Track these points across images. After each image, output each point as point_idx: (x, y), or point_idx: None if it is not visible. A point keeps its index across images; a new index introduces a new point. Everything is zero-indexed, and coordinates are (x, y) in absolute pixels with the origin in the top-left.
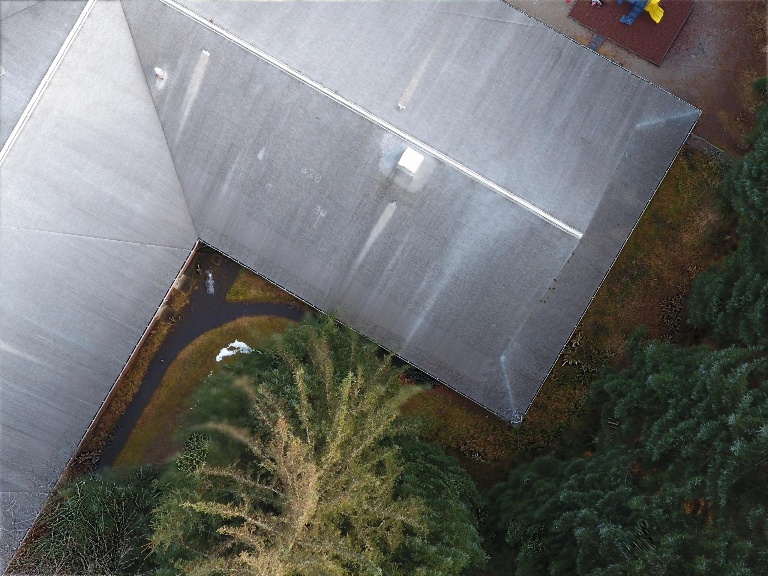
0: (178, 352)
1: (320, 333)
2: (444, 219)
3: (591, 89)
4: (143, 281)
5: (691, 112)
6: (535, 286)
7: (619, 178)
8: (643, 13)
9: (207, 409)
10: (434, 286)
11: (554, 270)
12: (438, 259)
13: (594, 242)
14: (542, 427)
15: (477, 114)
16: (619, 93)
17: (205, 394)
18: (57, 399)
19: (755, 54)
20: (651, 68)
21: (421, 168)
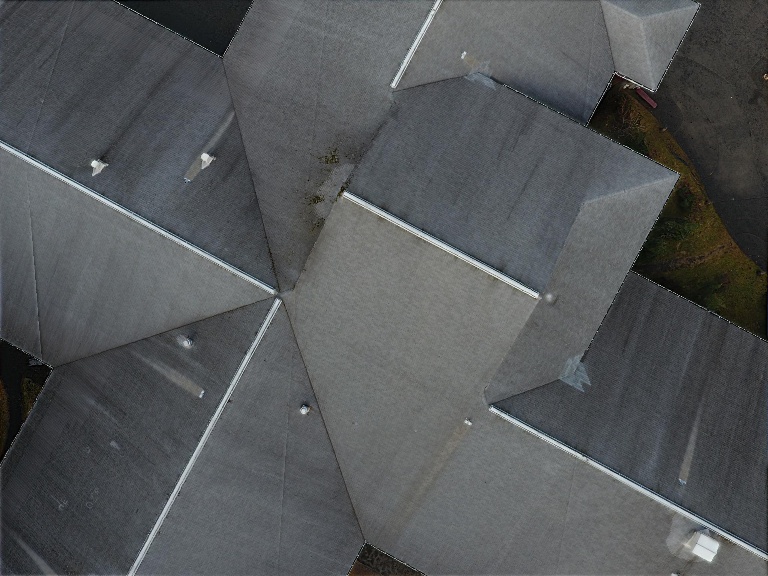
0: None
1: None
2: None
3: None
4: (6, 317)
5: None
6: None
7: None
8: None
9: None
10: None
11: None
12: None
13: None
14: None
15: None
16: None
17: None
18: None
19: None
20: None
21: None
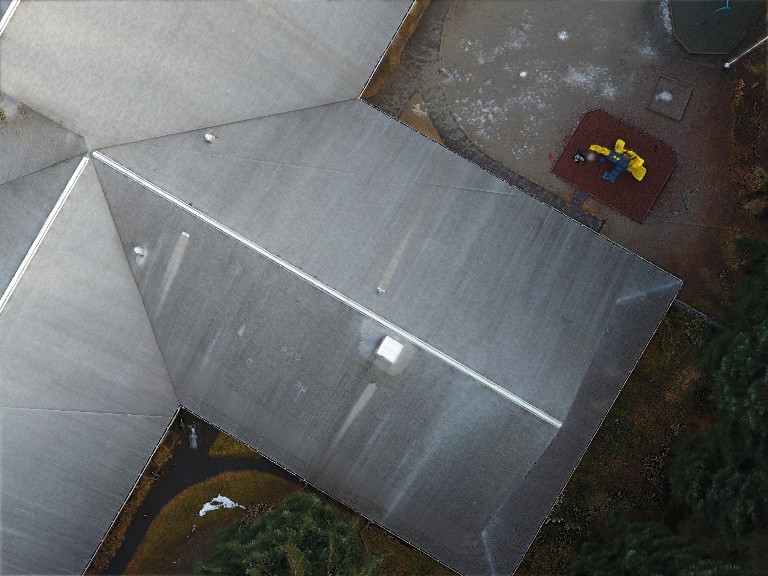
0: (161, 507)
1: (298, 531)
2: (424, 402)
3: (572, 262)
4: (124, 450)
5: (672, 283)
6: (515, 469)
7: (600, 352)
8: (625, 172)
9: (190, 563)
10: (415, 463)
11: (534, 455)
12: (418, 438)
13: (575, 415)
14: None
15: (457, 295)
16: (600, 265)
17: (188, 548)
18: (38, 569)
19: (738, 210)
20: (634, 225)
21: (401, 353)
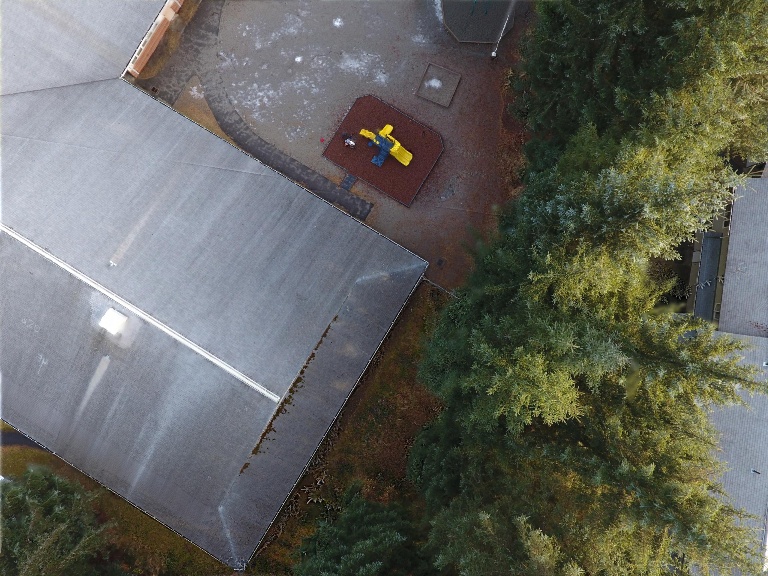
0: None
1: (4, 499)
2: (154, 375)
3: (316, 242)
4: None
5: (417, 265)
6: (242, 443)
7: (341, 331)
8: (390, 157)
9: None
10: (151, 437)
11: (257, 430)
12: (152, 412)
13: (316, 393)
14: (285, 565)
15: (191, 270)
16: (345, 245)
17: None
18: None
19: (505, 196)
20: (401, 209)
21: (128, 326)
